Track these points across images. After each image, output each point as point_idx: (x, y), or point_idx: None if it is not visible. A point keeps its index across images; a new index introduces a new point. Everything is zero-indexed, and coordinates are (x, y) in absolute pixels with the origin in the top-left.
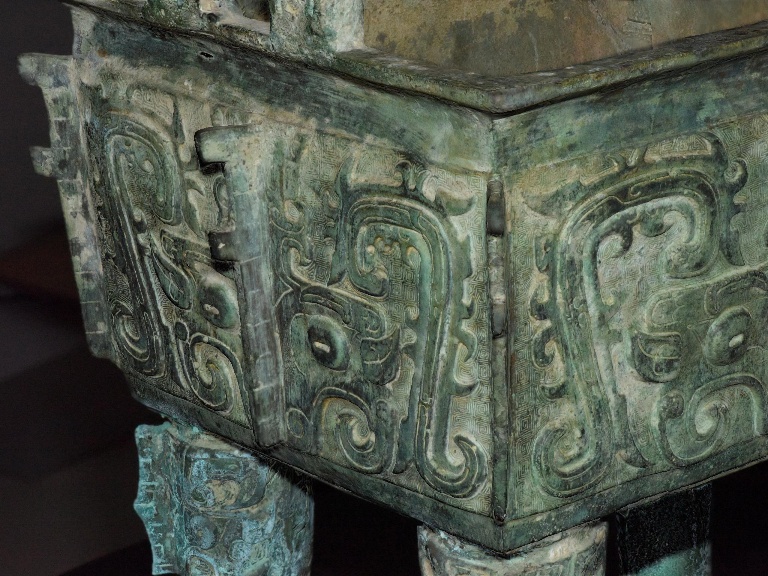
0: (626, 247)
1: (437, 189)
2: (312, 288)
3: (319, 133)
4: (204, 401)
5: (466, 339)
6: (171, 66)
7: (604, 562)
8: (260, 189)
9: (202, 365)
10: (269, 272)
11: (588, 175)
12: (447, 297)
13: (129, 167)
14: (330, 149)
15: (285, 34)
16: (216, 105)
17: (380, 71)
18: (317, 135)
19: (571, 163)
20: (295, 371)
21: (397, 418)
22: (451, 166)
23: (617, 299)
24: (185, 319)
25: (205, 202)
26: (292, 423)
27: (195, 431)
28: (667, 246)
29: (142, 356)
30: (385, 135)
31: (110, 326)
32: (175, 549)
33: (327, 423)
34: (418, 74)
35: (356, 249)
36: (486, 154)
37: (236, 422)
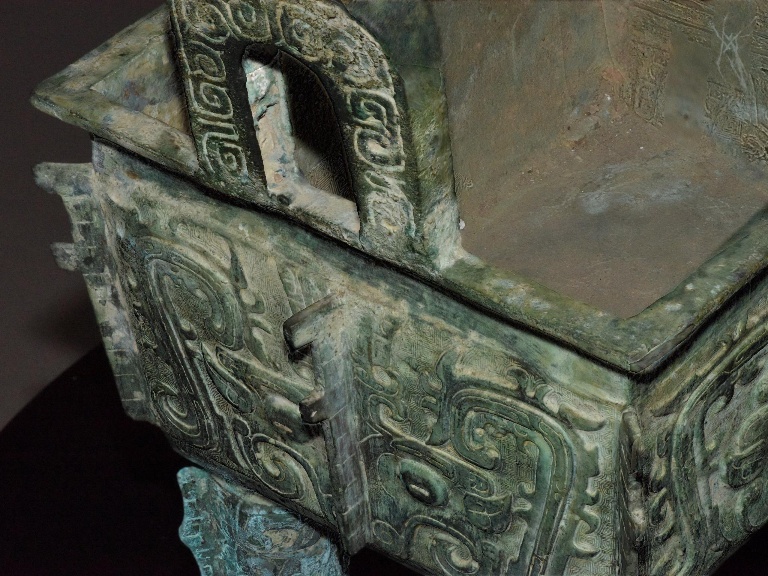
0: (728, 401)
1: (561, 404)
2: (408, 442)
3: (414, 319)
4: (269, 486)
5: (589, 520)
6: (219, 205)
7: None
8: (344, 351)
9: (265, 456)
10: (354, 416)
11: (702, 365)
12: (569, 486)
13: (175, 287)
14: (428, 336)
15: (379, 243)
16: (284, 263)
17: (499, 305)
18: (412, 321)
19: (689, 364)
20: (382, 493)
21: (505, 557)
22: (578, 390)
23: (718, 442)
24: (245, 418)
25: (272, 339)
26: (379, 532)
27: (249, 490)
28: (759, 380)
29: (191, 432)
30: (493, 336)
31: (148, 395)
32: (224, 568)
33: (420, 539)
34: (546, 319)
35: (464, 430)
36: (620, 389)
37: (308, 510)
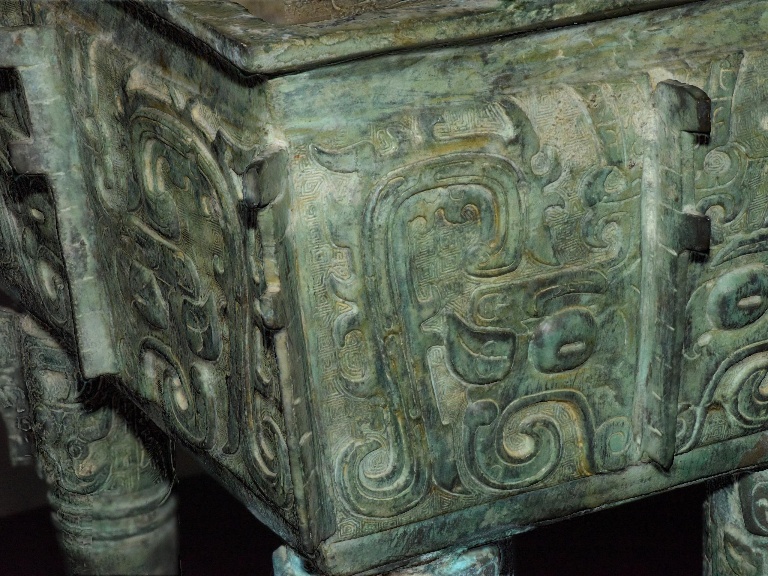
0: None
1: None
2: None
3: None
4: None
5: None
6: None
7: (80, 382)
8: None
9: None
10: None
11: None
12: None
13: None
14: None
15: None
16: None
17: None
18: None
19: None
20: None
21: None
22: None
23: None
24: None
25: None
26: None
27: None
28: None
29: None
30: None
31: None
32: None
33: None
34: None
35: None
36: None
37: None
